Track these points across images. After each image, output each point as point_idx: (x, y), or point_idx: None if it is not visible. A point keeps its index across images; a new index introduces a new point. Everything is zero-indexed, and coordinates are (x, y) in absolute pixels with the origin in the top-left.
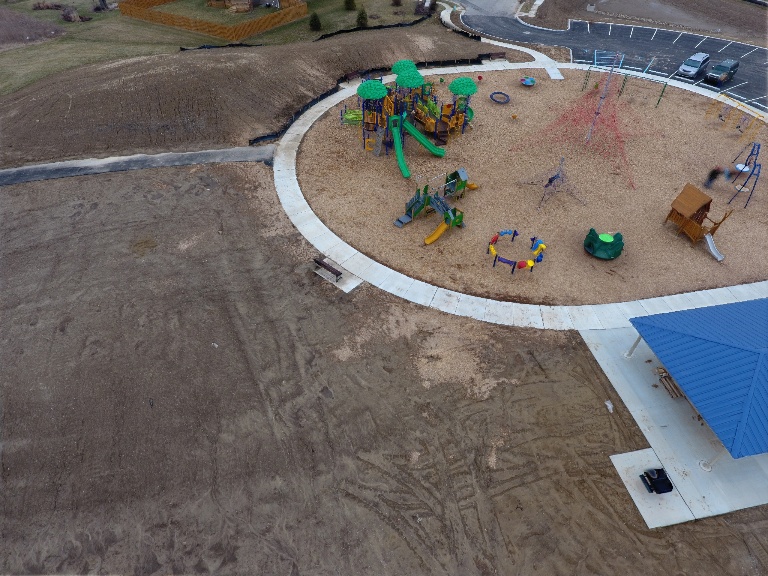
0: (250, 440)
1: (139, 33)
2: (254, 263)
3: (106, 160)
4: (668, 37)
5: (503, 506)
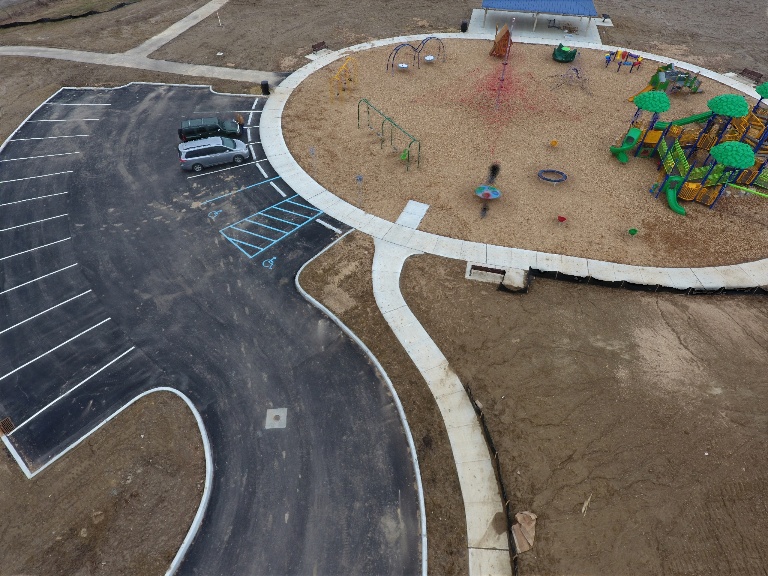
0: (762, 46)
1: None
2: None
3: None
4: (26, 263)
5: None
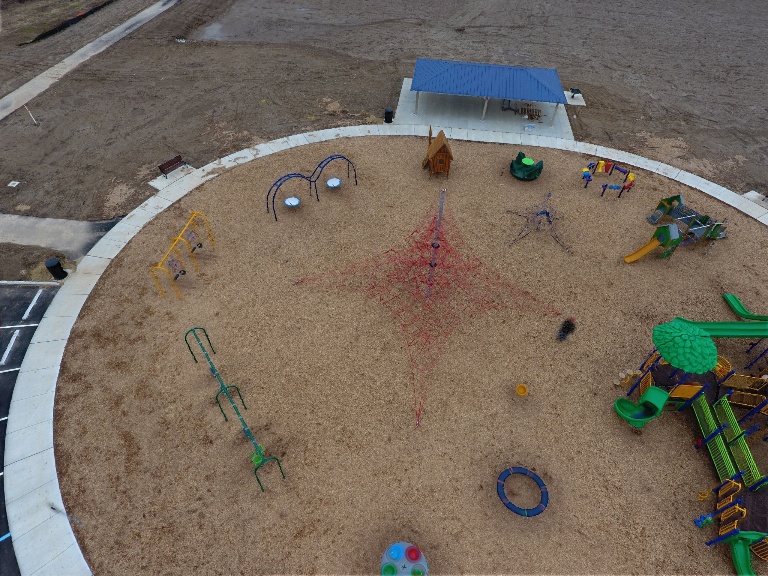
0: None
1: None
2: None
3: None
4: None
5: (640, 109)
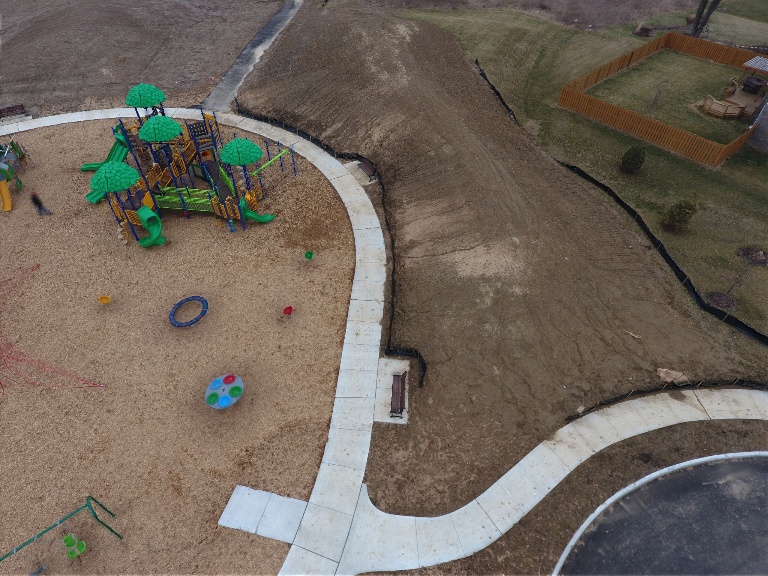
0: None
1: (591, 57)
2: (60, 92)
3: (260, 52)
4: None
5: None
